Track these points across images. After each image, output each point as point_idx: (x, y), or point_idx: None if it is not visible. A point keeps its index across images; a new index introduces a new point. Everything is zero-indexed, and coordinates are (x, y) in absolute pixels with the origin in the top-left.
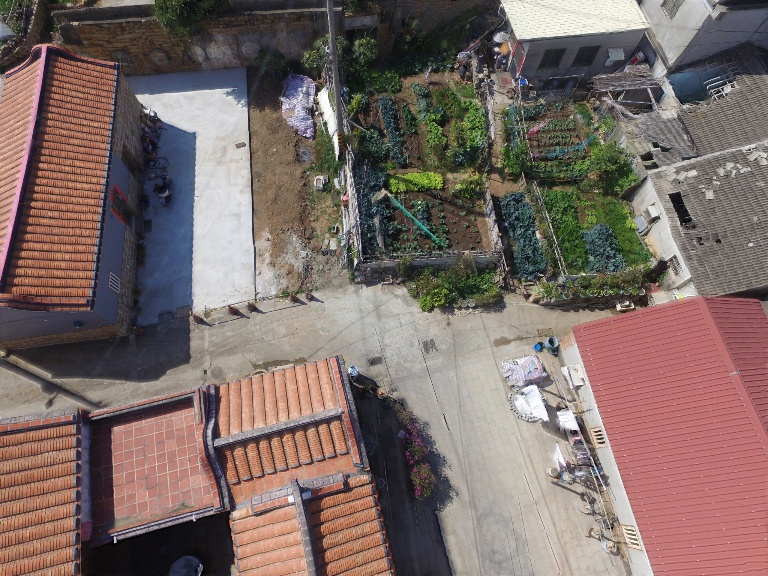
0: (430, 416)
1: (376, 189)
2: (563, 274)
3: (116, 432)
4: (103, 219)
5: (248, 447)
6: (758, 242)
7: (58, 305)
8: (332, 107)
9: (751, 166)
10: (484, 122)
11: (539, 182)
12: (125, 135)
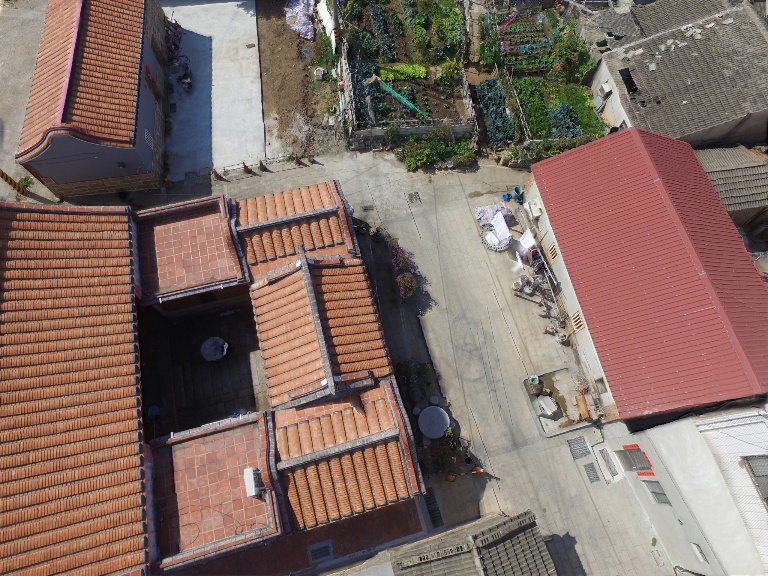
0: (414, 248)
1: (368, 76)
2: (528, 138)
3: (158, 230)
4: (139, 83)
5: (263, 235)
6: (691, 100)
7: (107, 140)
8: (329, 12)
9: (688, 41)
10: (462, 25)
11: (510, 73)
12: (153, 29)
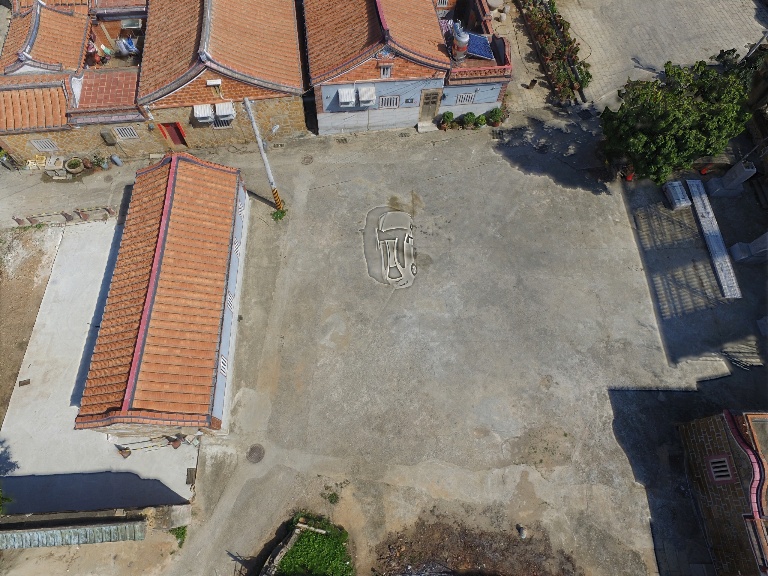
0: None
1: None
2: None
3: None
4: None
5: None
6: None
7: None
8: None
9: None
10: None
11: None
12: None
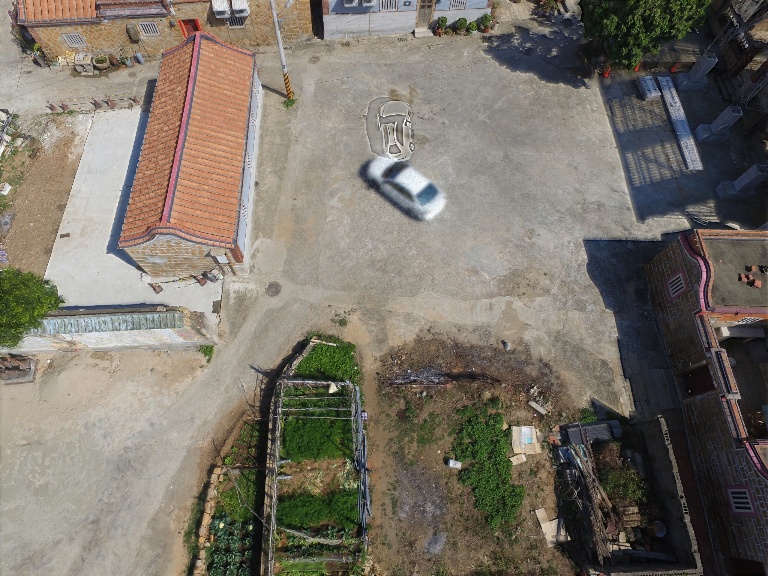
0: (8, 44)
1: None
2: None
3: None
4: None
5: None
6: None
7: None
8: None
9: None
10: None
11: None
12: None
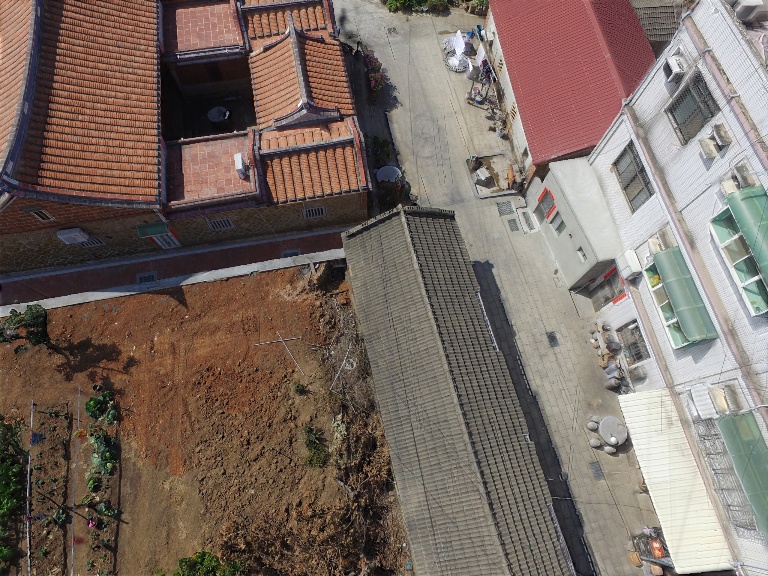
0: (388, 66)
1: None
2: None
3: (179, 12)
4: None
5: (262, 16)
6: None
7: None
8: None
9: None
10: None
11: None
12: None
